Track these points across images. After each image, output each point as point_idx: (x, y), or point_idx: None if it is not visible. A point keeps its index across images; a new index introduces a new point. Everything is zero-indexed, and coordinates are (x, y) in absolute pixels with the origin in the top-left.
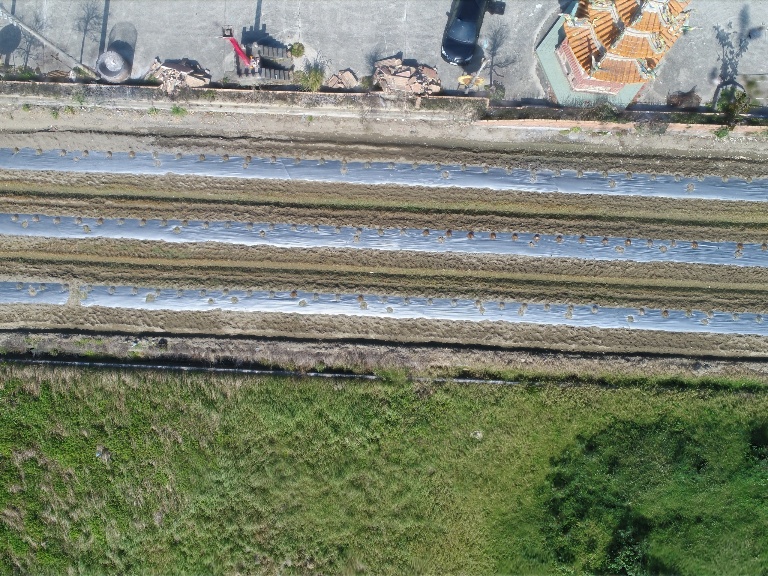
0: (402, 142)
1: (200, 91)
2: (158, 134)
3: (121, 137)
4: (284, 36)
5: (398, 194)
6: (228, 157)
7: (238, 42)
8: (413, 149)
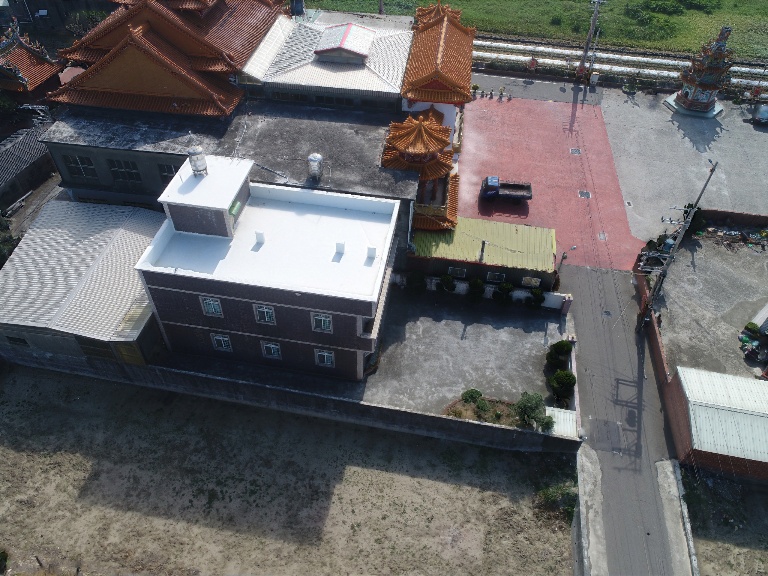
0: None
1: None
2: None
3: None
4: None
5: (766, 93)
6: None
7: None
8: None
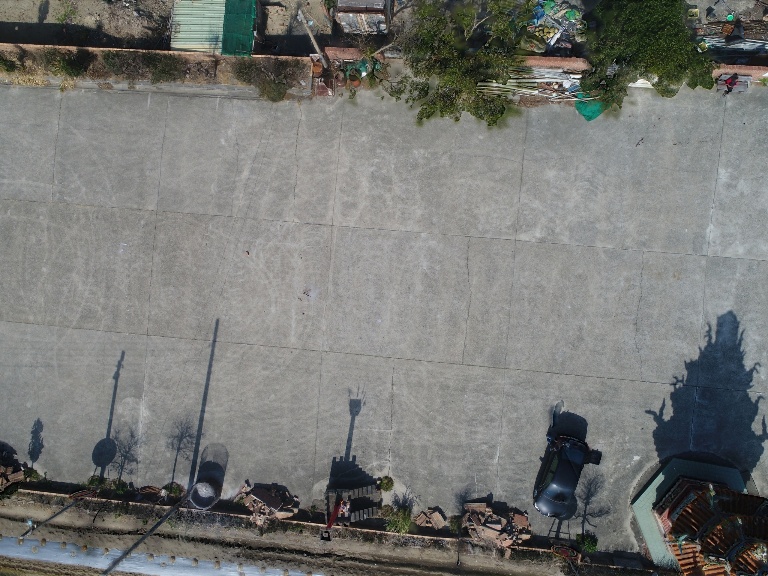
0: (487, 571)
1: (289, 524)
2: (244, 545)
3: (208, 546)
4: (374, 469)
5: None
6: (312, 574)
7: (327, 471)
8: None
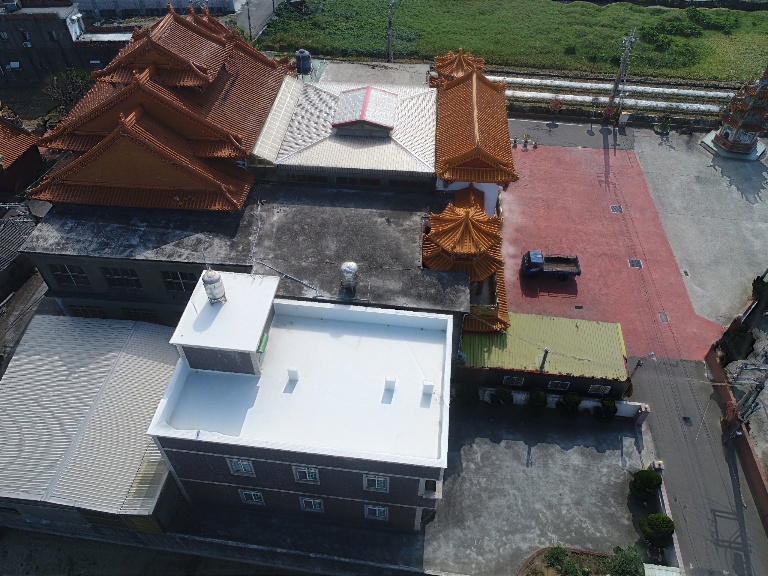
0: None
1: None
2: None
3: None
4: None
5: None
6: None
7: None
8: None
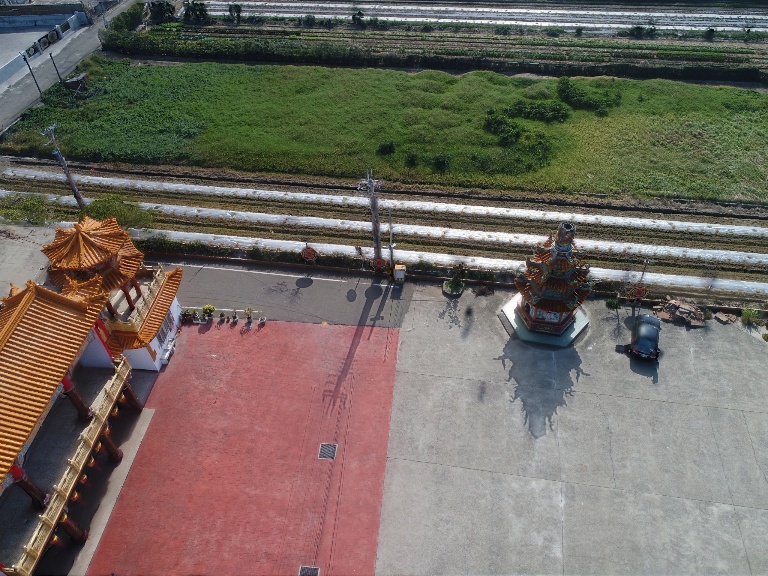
0: None
1: None
2: None
3: None
4: None
5: None
6: None
7: None
8: (660, 291)
